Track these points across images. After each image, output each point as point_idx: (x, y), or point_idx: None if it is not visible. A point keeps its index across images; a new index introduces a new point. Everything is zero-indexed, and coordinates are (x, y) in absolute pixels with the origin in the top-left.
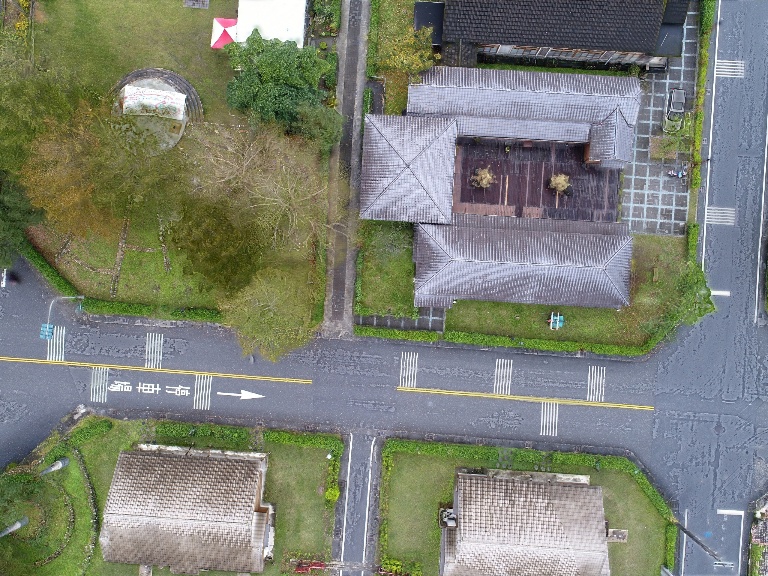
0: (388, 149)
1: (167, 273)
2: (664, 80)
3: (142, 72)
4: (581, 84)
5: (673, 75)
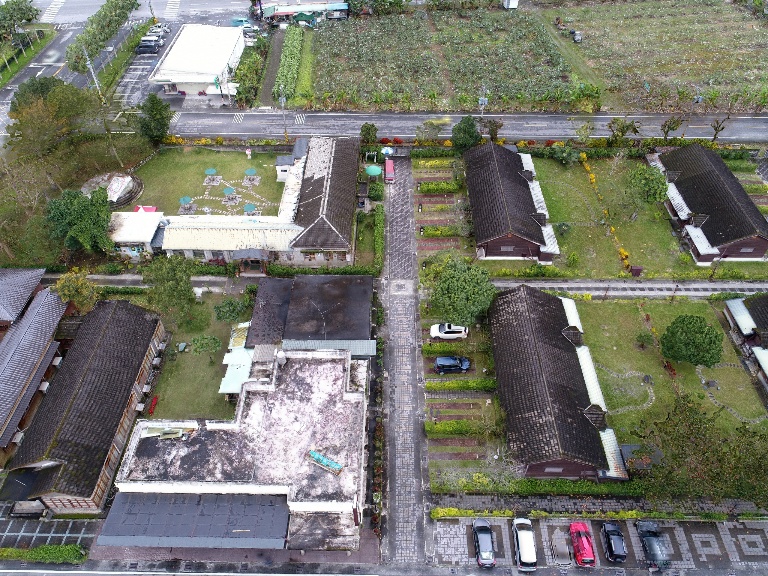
0: (8, 277)
1: (4, 200)
2: (1, 515)
3: (140, 186)
4: (0, 402)
5: (2, 524)
